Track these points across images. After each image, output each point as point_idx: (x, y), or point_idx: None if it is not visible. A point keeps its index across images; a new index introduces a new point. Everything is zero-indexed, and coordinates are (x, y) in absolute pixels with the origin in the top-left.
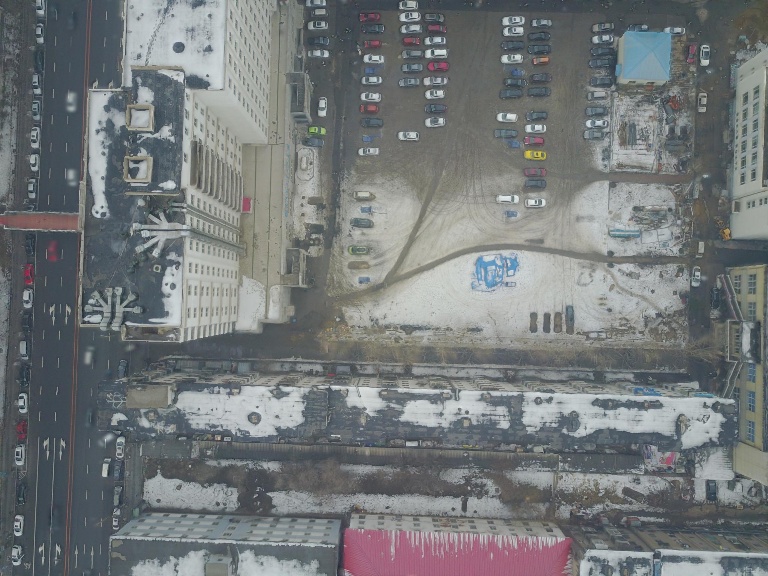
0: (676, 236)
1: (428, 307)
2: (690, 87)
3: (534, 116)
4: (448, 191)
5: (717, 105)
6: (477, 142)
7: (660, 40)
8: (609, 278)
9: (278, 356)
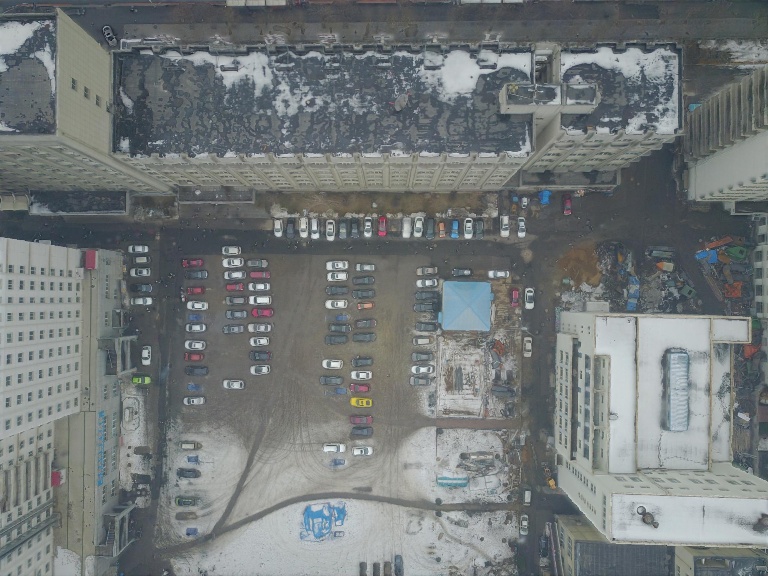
0: (504, 483)
1: (257, 558)
2: (516, 330)
3: (359, 363)
4: (275, 439)
5: (543, 348)
6: (303, 388)
7: (478, 293)
8: (438, 526)
9: None
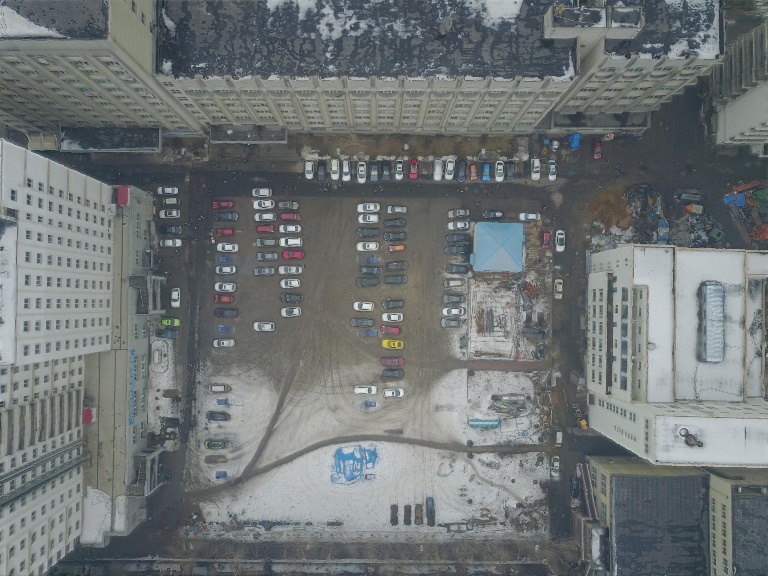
0: (535, 425)
1: (287, 501)
2: (547, 272)
3: (390, 305)
4: (306, 382)
5: (574, 290)
6: (334, 331)
7: (511, 233)
8: (469, 468)
9: (134, 555)
